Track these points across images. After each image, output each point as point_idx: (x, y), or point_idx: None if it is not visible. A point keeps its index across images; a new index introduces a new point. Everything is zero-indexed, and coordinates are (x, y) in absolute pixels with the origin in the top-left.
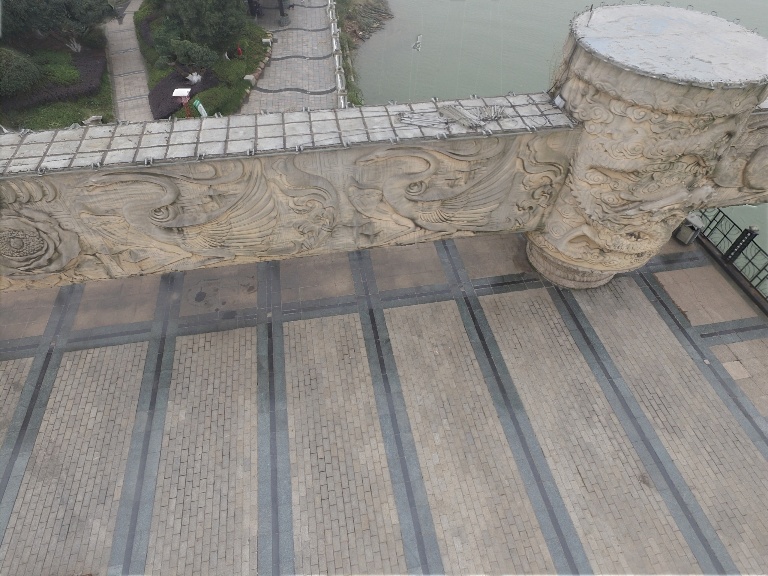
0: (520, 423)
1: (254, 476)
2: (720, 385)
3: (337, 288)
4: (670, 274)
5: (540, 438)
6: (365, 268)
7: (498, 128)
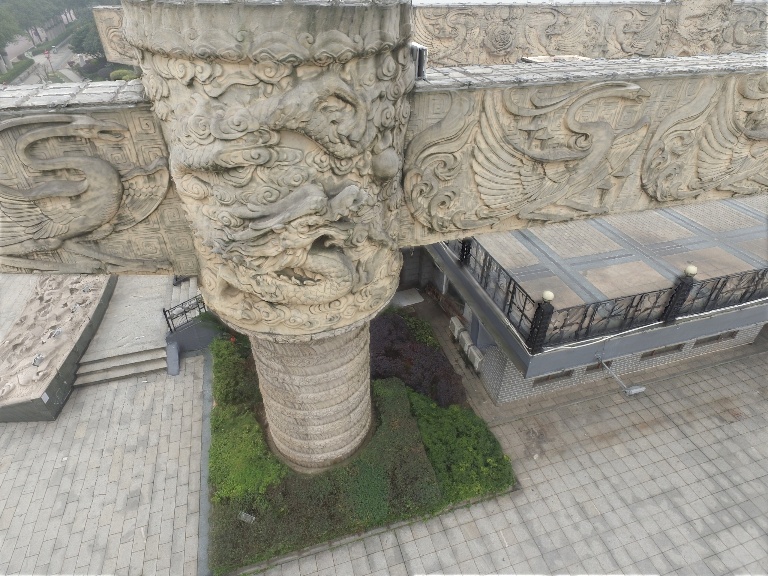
0: None
1: None
2: None
3: None
4: None
5: None
6: None
7: (655, 3)
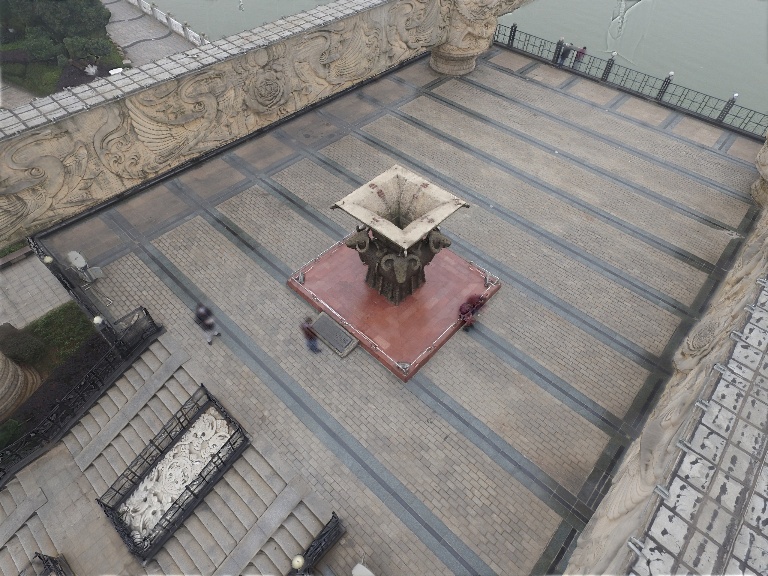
0: (485, 118)
1: (410, 169)
2: (537, 84)
3: (368, 110)
4: (494, 59)
5: (495, 119)
6: (371, 99)
7: None
